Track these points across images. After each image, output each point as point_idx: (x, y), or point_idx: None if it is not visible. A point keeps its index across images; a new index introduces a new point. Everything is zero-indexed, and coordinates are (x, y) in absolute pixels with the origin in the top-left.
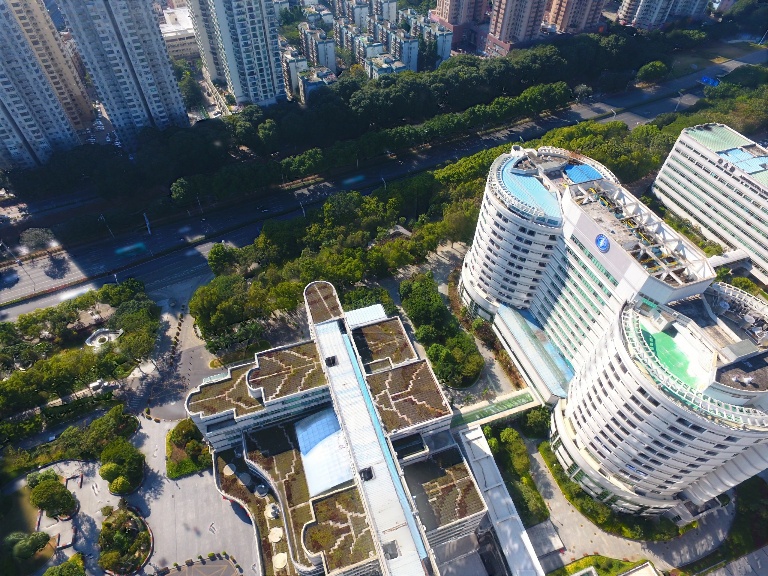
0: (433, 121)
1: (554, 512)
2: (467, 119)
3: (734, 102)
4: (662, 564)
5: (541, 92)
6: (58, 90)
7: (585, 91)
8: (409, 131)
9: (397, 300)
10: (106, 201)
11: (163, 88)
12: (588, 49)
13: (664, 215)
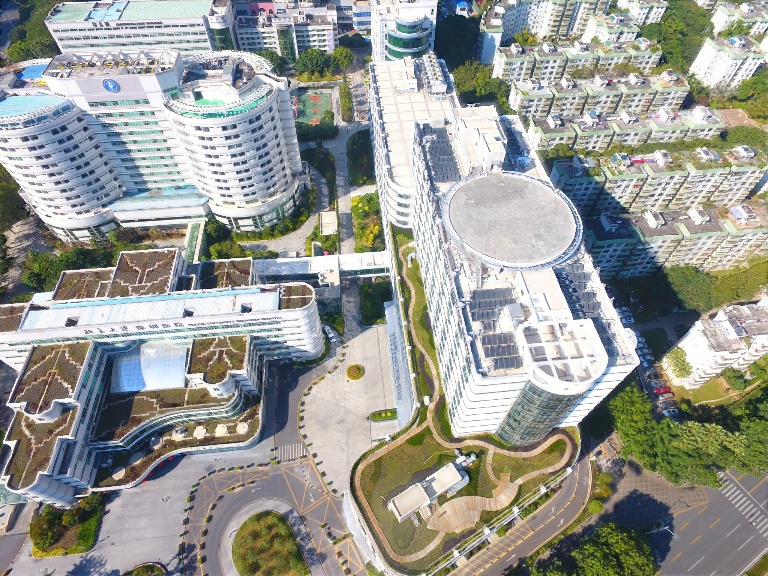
0: None
1: (276, 249)
2: None
3: None
4: None
5: None
6: None
7: None
8: None
9: None
10: None
11: None
12: None
13: None
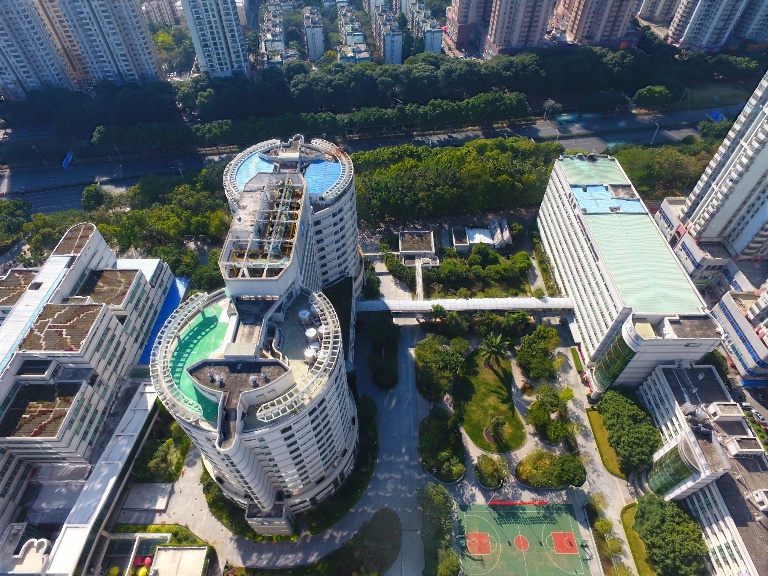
0: (359, 113)
1: (183, 479)
2: (394, 116)
3: (716, 143)
4: (236, 558)
5: (486, 100)
6: (70, 42)
7: (551, 107)
8: (326, 118)
9: None
10: (62, 137)
11: (134, 50)
12: (582, 63)
13: (534, 248)
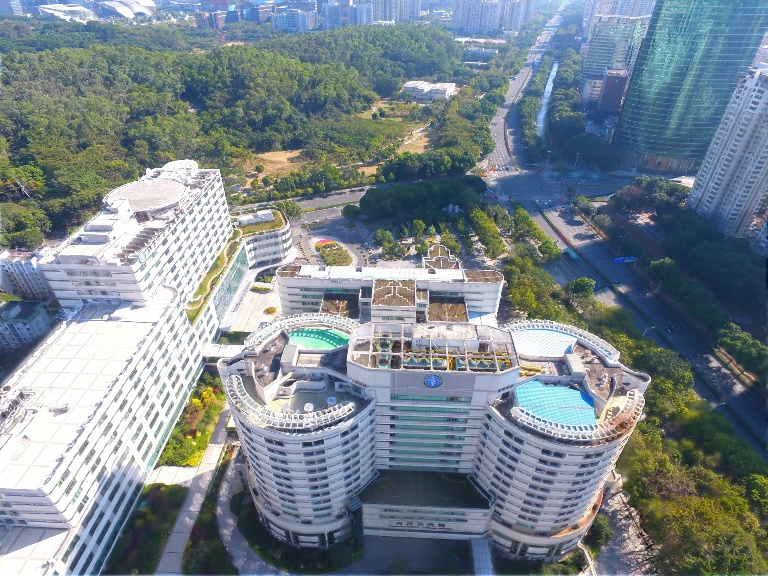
0: None
1: None
2: None
3: None
4: None
5: None
6: None
7: None
8: None
9: None
10: None
11: None
12: None
13: None
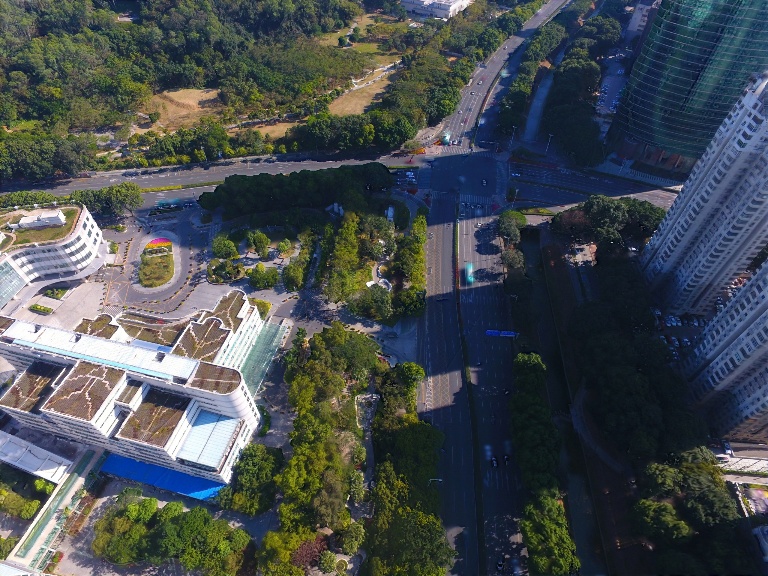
0: None
1: None
2: None
3: None
4: None
5: None
6: None
7: None
8: None
9: (247, 530)
10: None
11: (764, 377)
12: None
13: None
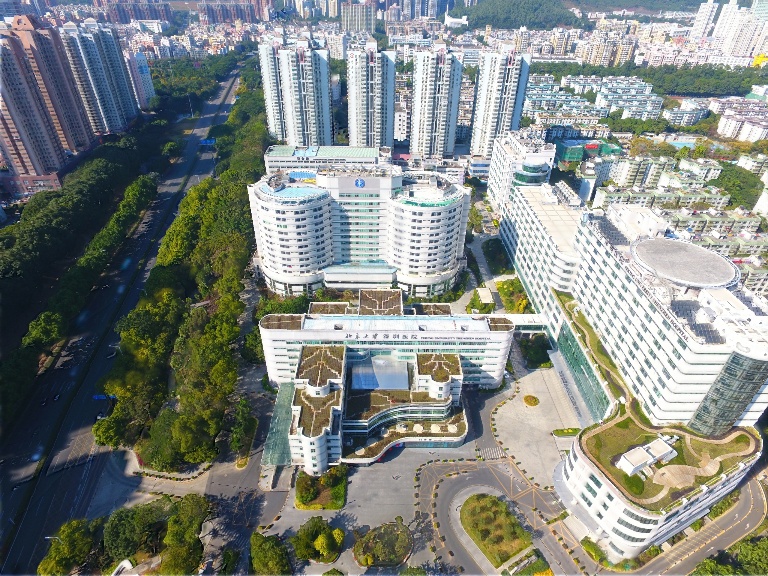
0: (96, 243)
1: None
2: (118, 227)
3: (239, 143)
4: None
5: (140, 186)
6: None
7: (156, 176)
8: (94, 256)
9: None
10: None
11: None
12: (120, 153)
13: None
